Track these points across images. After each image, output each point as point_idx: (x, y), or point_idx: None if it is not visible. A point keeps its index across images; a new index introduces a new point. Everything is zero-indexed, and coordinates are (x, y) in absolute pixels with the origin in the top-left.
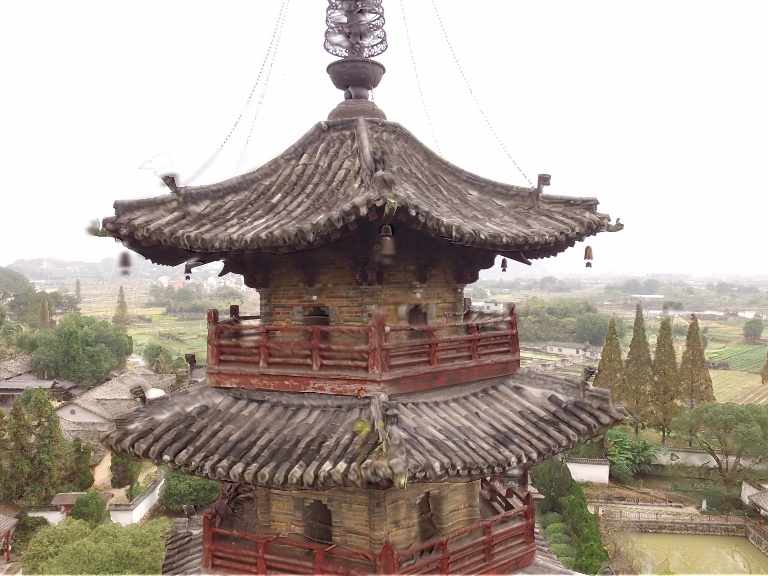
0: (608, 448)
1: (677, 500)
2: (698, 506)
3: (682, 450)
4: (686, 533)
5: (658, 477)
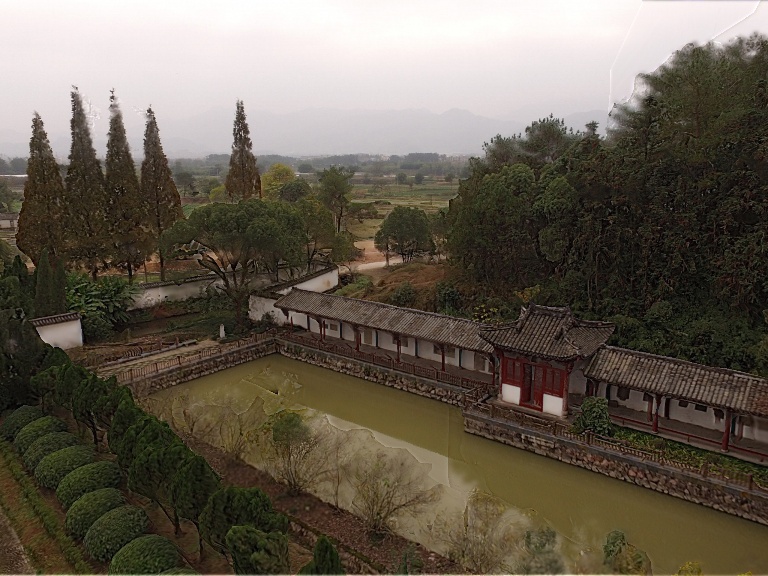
0: (68, 299)
1: (182, 340)
2: (214, 337)
3: (161, 284)
4: (216, 371)
5: (138, 325)
